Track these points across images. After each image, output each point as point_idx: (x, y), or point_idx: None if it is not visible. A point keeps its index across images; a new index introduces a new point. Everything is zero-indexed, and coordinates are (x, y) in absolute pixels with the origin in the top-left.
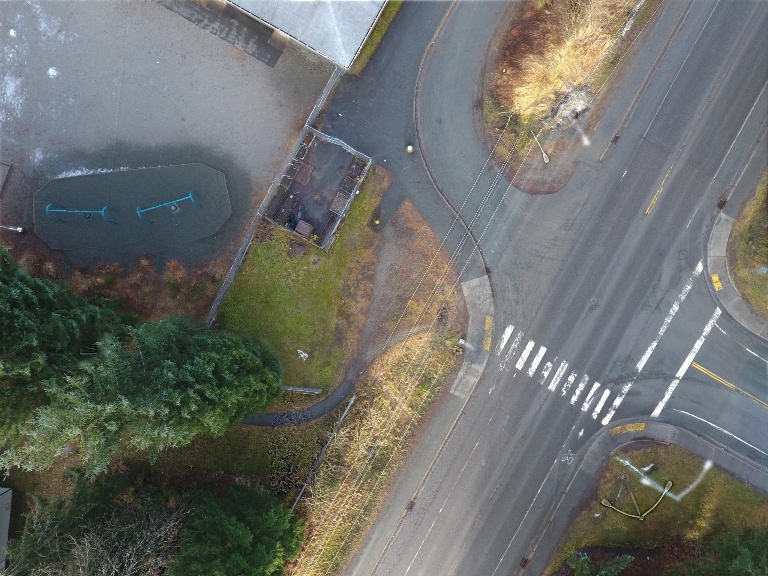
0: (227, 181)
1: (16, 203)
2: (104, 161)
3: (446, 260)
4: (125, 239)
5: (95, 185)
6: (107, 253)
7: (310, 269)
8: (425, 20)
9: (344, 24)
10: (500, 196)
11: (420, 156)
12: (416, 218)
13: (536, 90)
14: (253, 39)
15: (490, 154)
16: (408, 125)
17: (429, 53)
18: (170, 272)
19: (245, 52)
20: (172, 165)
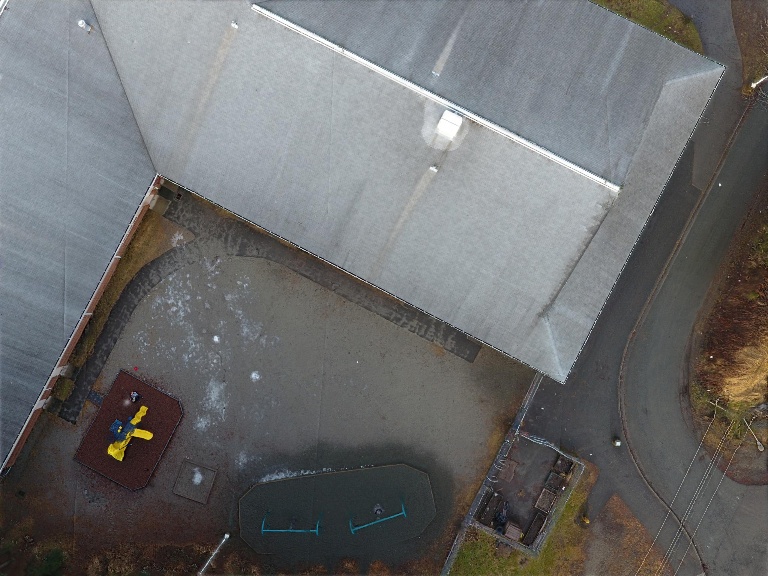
0: (430, 481)
1: (222, 507)
2: (307, 463)
3: (660, 557)
4: (330, 542)
5: (299, 489)
6: (312, 556)
7: (518, 570)
8: (626, 308)
9: (561, 342)
10: (713, 488)
11: (627, 449)
12: (626, 513)
13: (749, 380)
14: (451, 335)
15: (700, 443)
16: (613, 417)
17: (631, 341)
18: (374, 573)
19: (444, 349)
20: (375, 467)
